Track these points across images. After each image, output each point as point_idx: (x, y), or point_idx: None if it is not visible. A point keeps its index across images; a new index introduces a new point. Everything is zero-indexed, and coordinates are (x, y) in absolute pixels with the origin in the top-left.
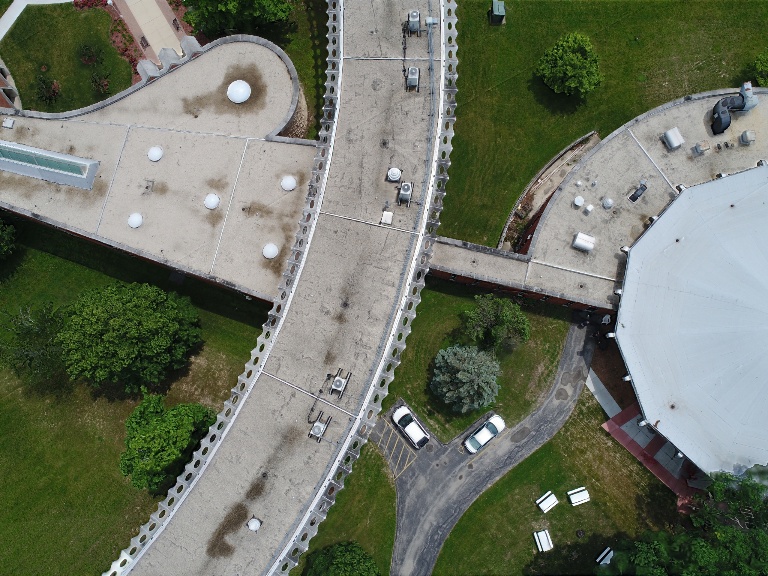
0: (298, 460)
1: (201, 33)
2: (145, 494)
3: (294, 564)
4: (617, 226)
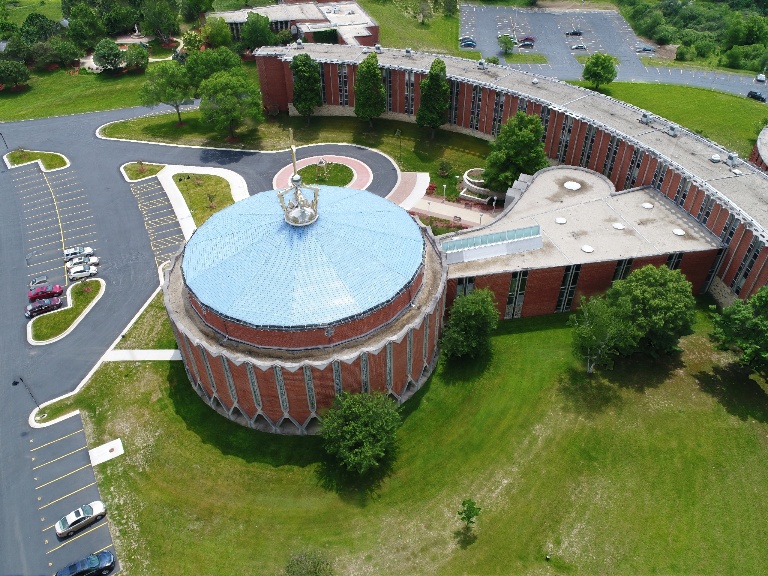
0: None
1: (486, 205)
2: (759, 425)
3: None
4: None
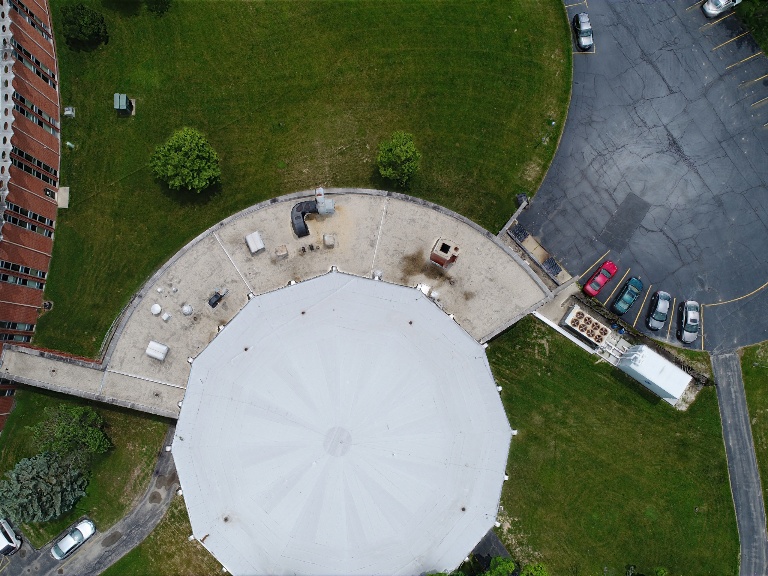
0: None
1: None
2: None
3: None
4: (196, 333)
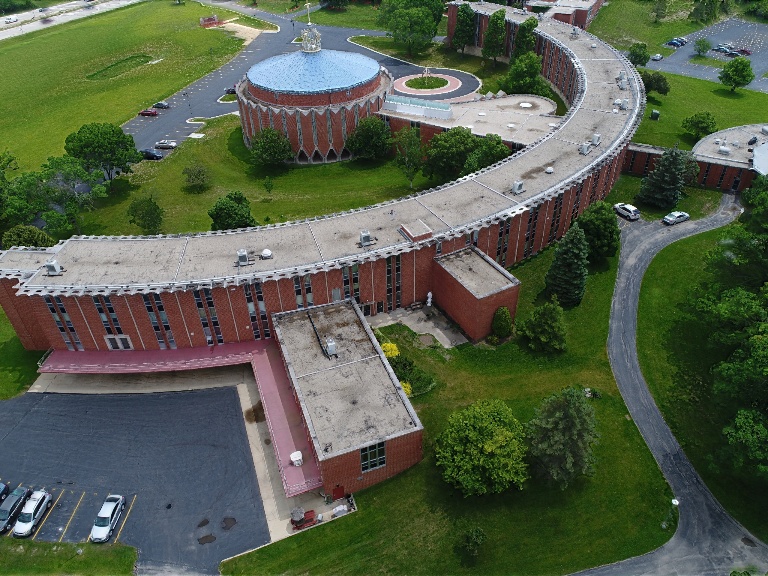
0: (573, 159)
1: None
2: None
3: (573, 185)
4: None
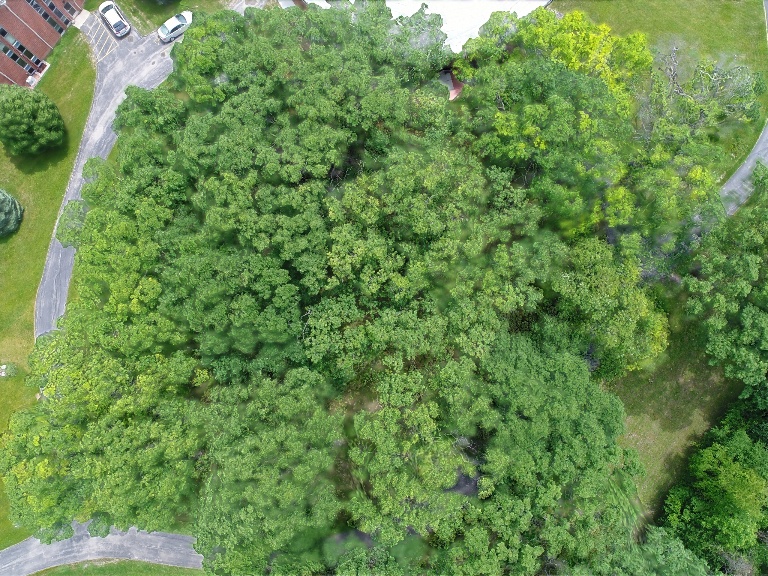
0: None
1: None
2: None
3: None
4: None
